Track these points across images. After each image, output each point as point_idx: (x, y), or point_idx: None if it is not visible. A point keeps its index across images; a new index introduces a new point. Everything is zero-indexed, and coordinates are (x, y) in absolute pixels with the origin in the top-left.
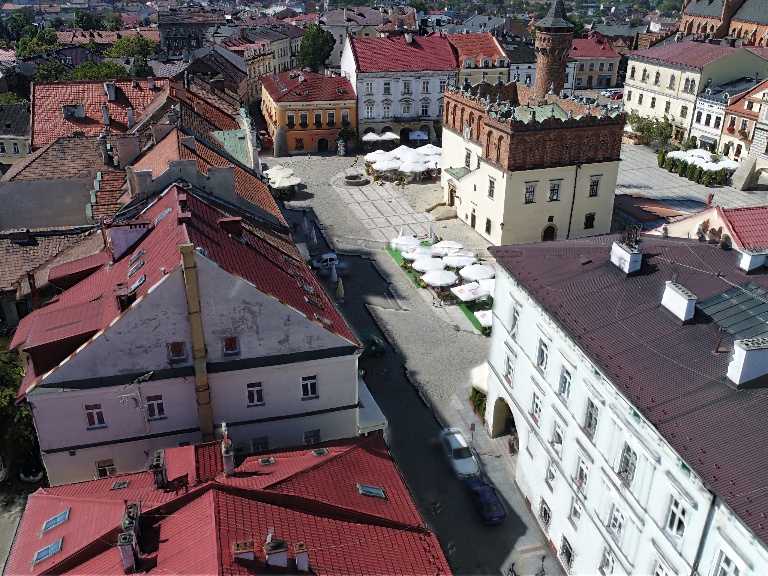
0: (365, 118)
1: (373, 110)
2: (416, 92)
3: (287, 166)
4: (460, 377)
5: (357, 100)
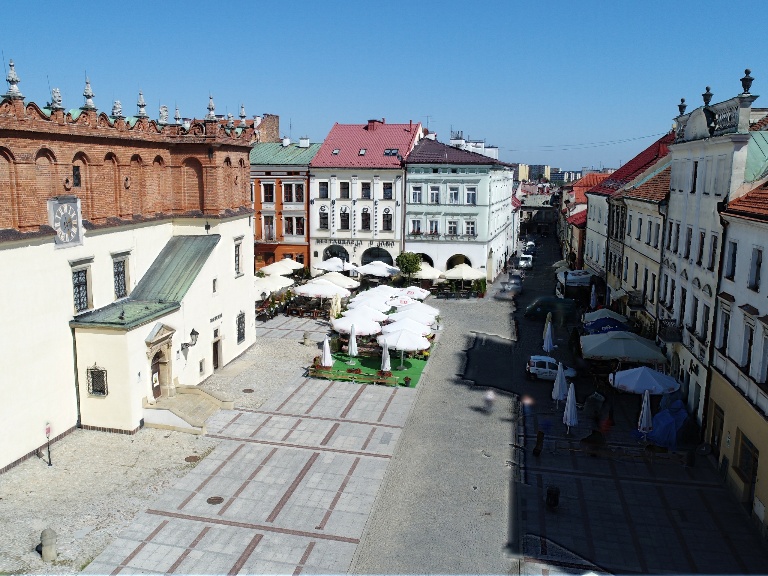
0: None
1: None
2: None
3: None
4: (475, 304)
5: None
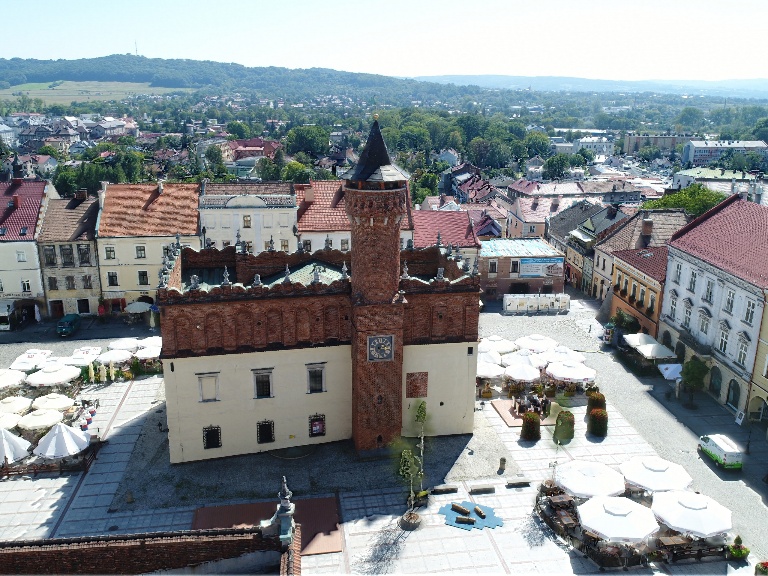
0: (667, 315)
1: (676, 307)
2: (717, 304)
3: (553, 321)
4: None
5: (665, 284)
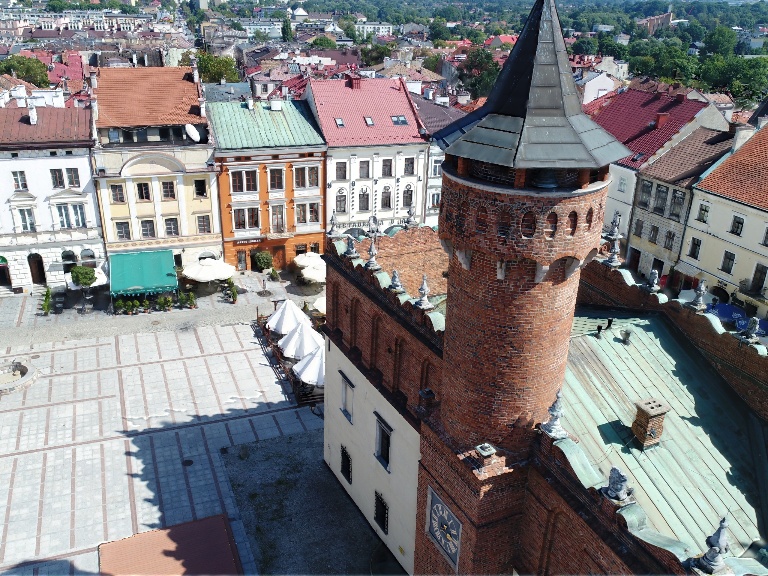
0: None
1: None
2: None
3: None
4: None
5: None
